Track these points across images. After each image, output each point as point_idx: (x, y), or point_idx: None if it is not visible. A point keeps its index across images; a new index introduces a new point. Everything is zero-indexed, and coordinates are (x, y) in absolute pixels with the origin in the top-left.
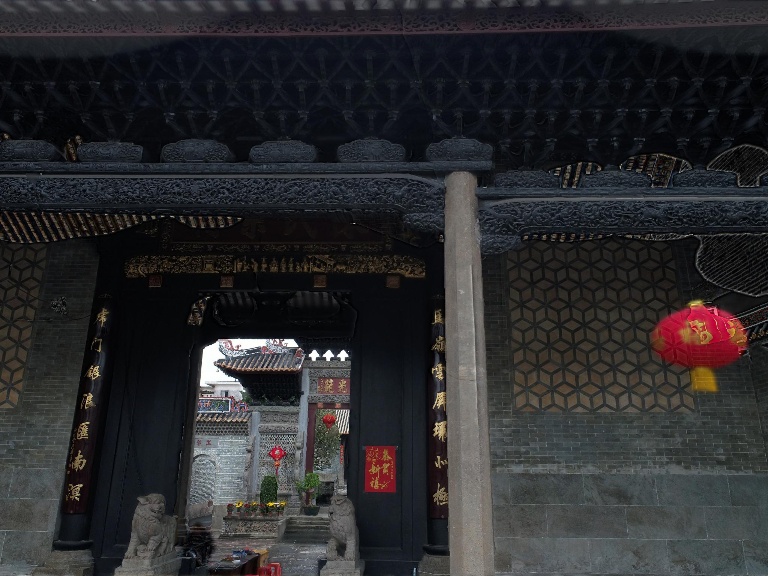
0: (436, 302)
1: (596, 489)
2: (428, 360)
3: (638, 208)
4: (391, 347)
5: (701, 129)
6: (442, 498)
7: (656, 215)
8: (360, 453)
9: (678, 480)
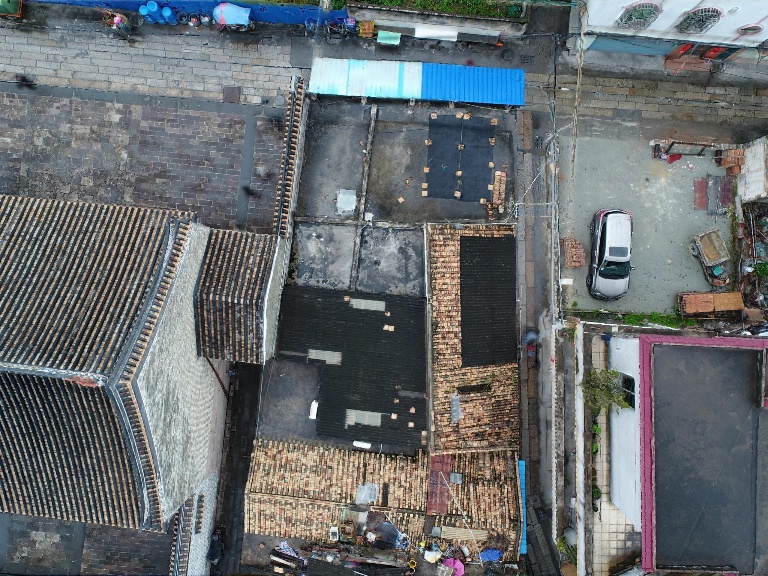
0: None
1: None
2: None
3: None
4: None
5: None
6: None
7: None
8: None
9: None
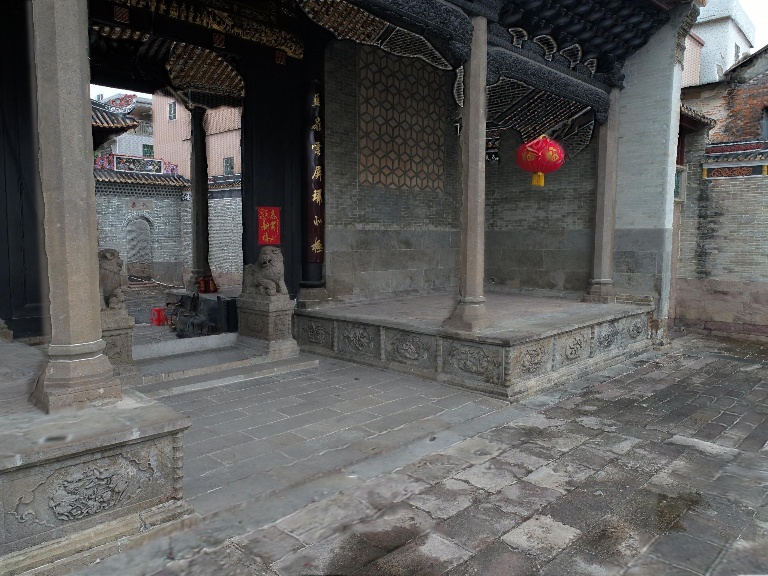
0: (315, 86)
1: (397, 240)
2: (304, 137)
3: (545, 73)
4: (275, 120)
5: (574, 30)
6: (318, 248)
7: (550, 80)
8: (254, 212)
9: (432, 234)
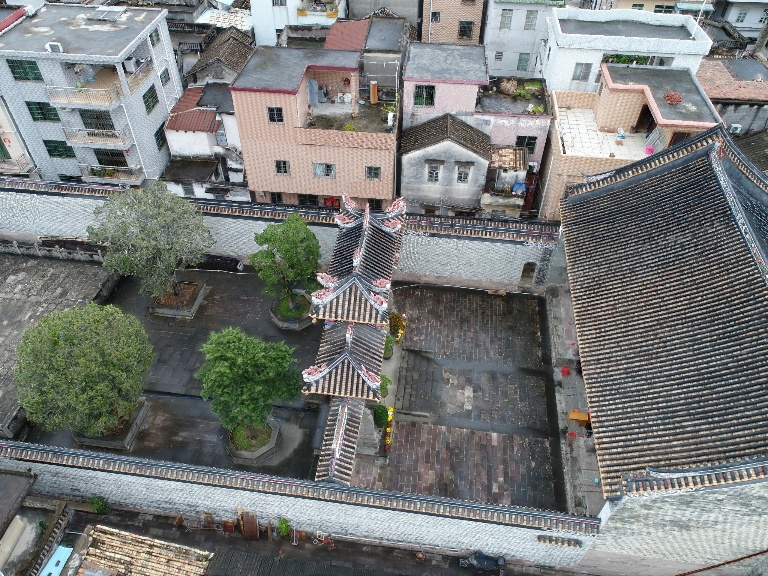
0: None
1: None
2: None
3: None
4: None
5: None
6: None
7: None
8: None
9: None
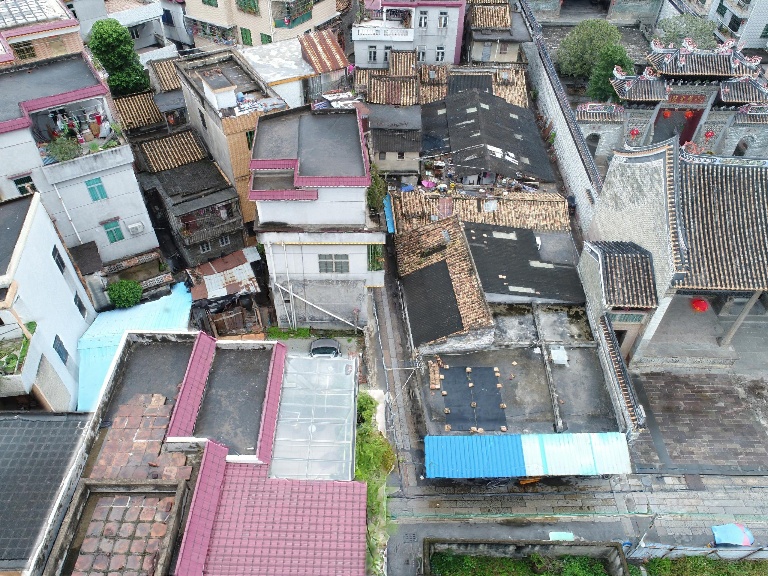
0: None
1: None
2: None
3: None
4: None
5: None
6: None
7: None
8: None
9: None
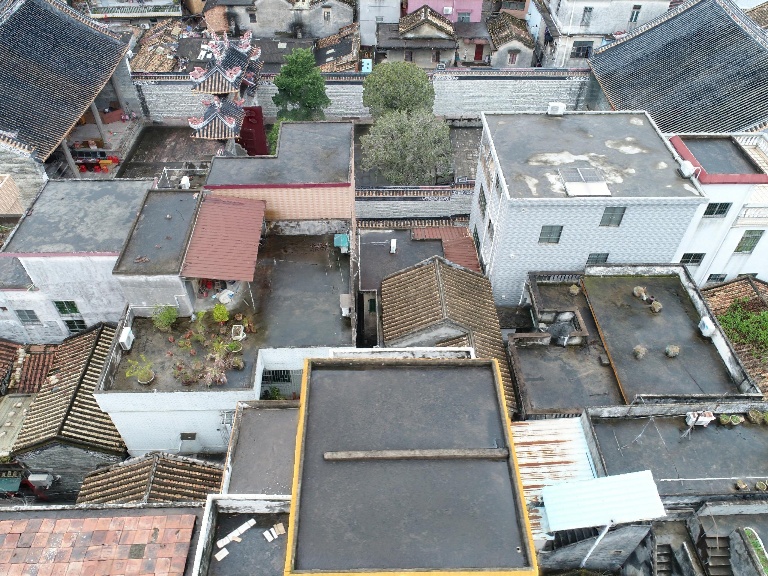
0: None
1: None
2: None
3: None
4: None
5: None
6: None
7: None
8: None
9: None
